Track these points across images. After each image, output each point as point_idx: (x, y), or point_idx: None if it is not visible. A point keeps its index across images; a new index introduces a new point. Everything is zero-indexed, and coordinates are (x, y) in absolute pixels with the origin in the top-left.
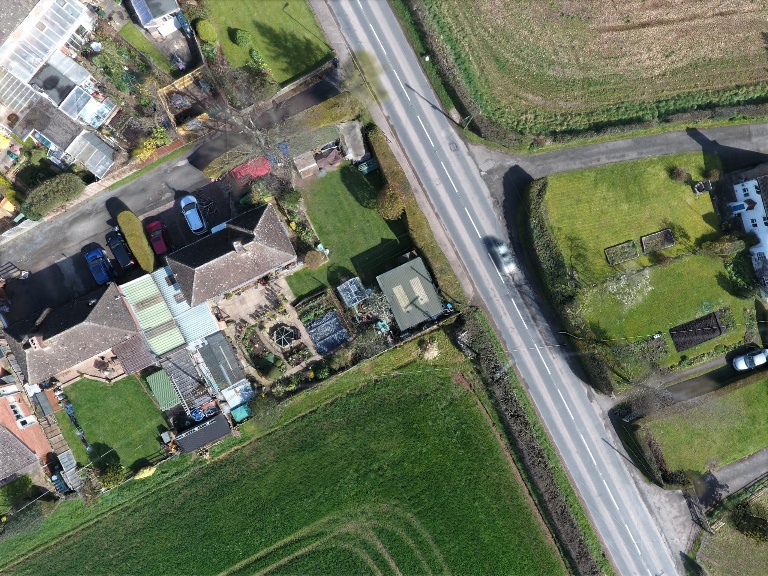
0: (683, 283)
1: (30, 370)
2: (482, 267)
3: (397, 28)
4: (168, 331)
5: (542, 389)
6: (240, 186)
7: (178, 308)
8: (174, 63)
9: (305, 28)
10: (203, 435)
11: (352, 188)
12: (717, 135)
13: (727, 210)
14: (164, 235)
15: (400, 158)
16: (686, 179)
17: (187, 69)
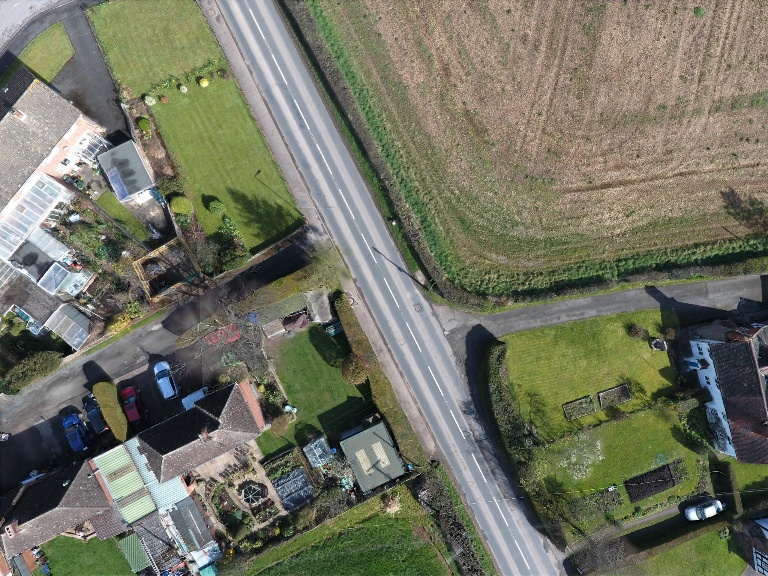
0: (638, 436)
1: (7, 548)
2: (444, 424)
3: (365, 193)
4: (139, 499)
5: (500, 540)
6: (211, 352)
7: (149, 476)
8: (149, 235)
9: (276, 194)
10: None
11: (320, 348)
12: (675, 292)
13: (683, 364)
14: (137, 402)
15: (366, 319)
16: (643, 336)
17: (162, 236)
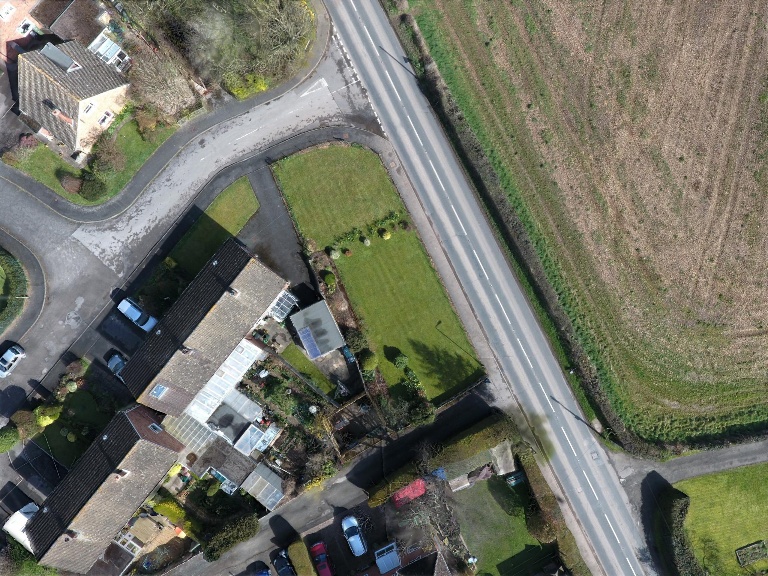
0: None
1: None
2: (620, 571)
3: (543, 342)
4: None
5: None
6: None
7: None
8: (338, 391)
9: (456, 344)
10: None
11: (498, 496)
12: None
13: None
14: (328, 560)
15: (544, 468)
16: None
17: None
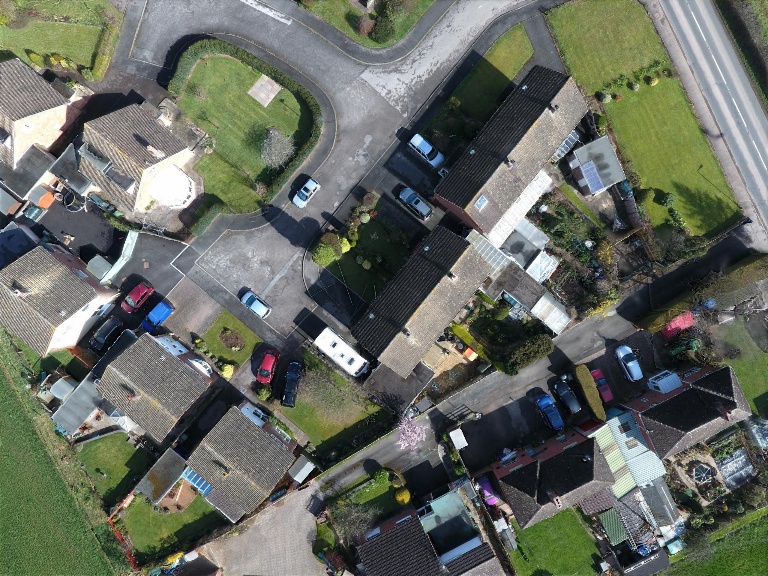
0: None
1: (532, 519)
2: None
3: None
4: (624, 476)
5: None
6: (669, 337)
7: (629, 453)
8: (614, 225)
9: (717, 188)
10: (647, 568)
11: (754, 334)
12: None
13: None
14: None
15: None
16: None
17: None
